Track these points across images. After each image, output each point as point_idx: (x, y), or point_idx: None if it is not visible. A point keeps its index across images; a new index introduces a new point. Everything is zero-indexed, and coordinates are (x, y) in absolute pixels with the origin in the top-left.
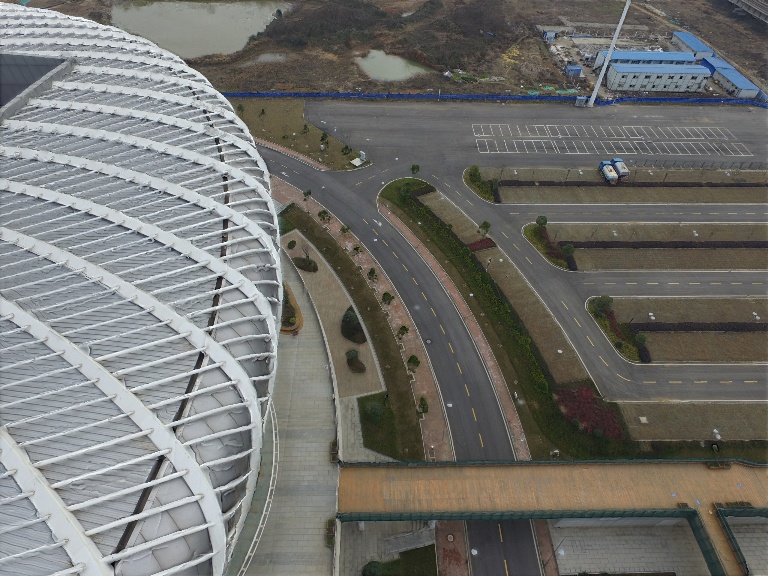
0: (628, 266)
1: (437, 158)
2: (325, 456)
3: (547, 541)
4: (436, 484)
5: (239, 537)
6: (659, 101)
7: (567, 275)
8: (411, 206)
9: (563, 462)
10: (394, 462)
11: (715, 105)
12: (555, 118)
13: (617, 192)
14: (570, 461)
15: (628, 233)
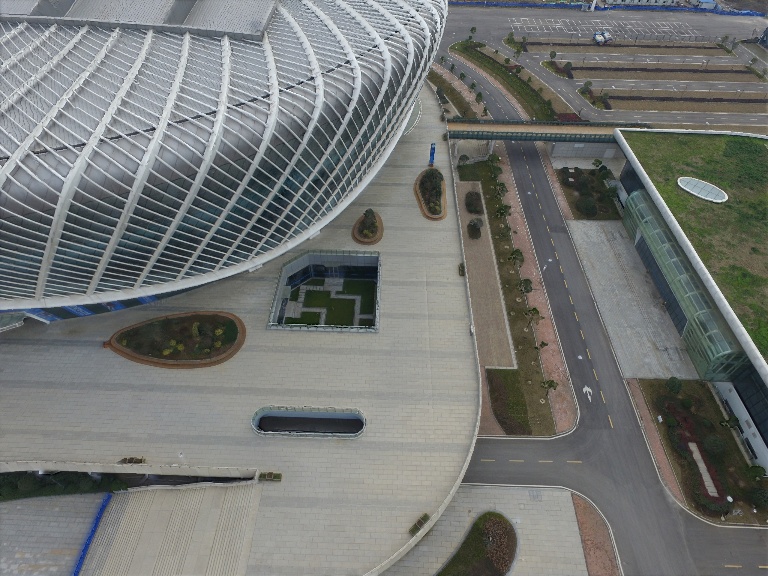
0: (605, 77)
1: (485, 33)
2: (438, 120)
3: (548, 160)
4: (494, 128)
5: (410, 119)
6: (642, 9)
7: (567, 80)
8: (471, 51)
9: (557, 122)
10: (473, 119)
11: (682, 12)
12: (566, 16)
13: (603, 49)
14: (561, 122)
15: (607, 65)
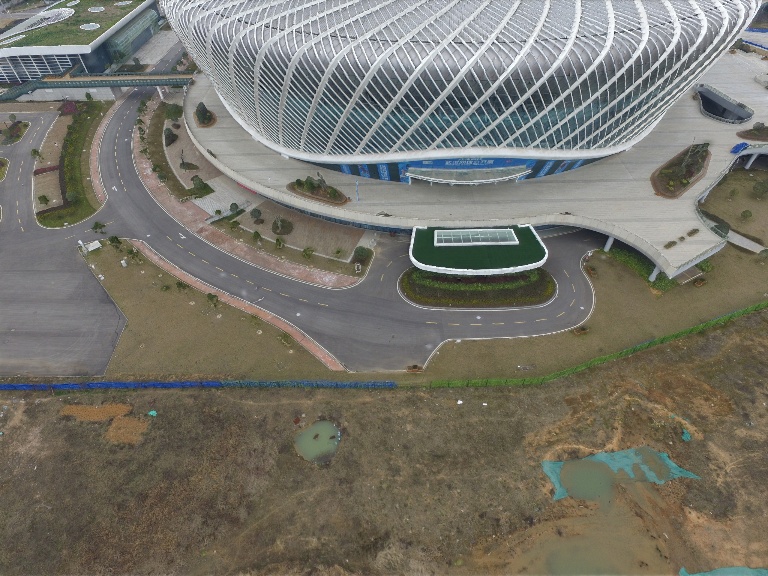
0: None
1: None
2: None
3: None
4: None
5: None
6: None
7: (7, 155)
8: None
9: None
10: None
11: None
12: None
13: None
14: (101, 80)
15: None
